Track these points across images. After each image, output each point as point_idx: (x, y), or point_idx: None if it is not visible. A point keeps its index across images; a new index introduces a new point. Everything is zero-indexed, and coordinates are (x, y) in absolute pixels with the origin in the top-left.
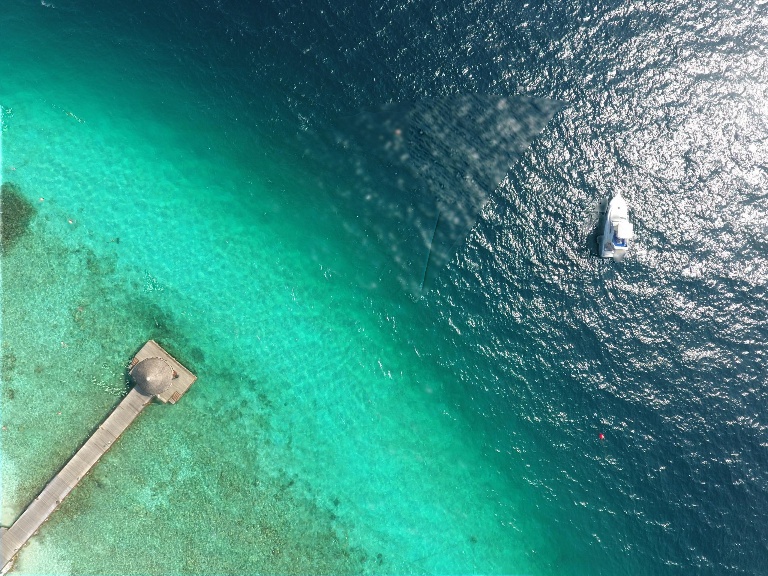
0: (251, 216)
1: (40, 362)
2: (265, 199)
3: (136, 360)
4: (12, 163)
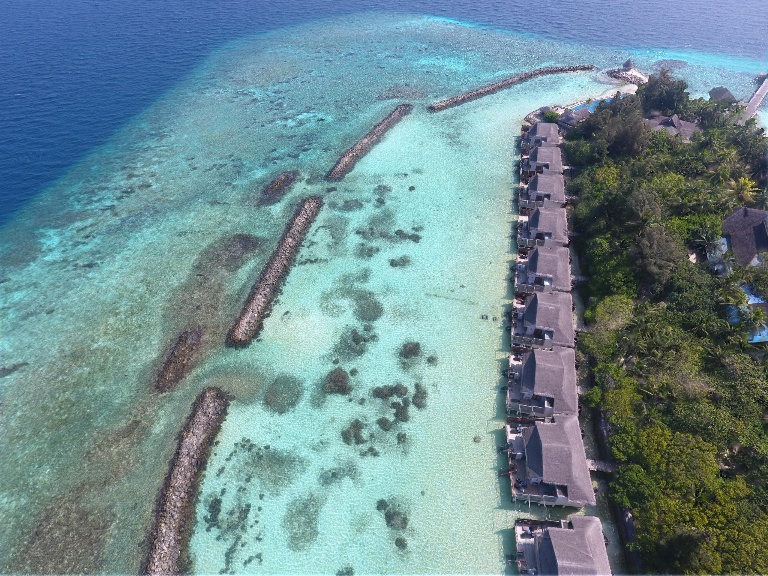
0: (762, 64)
1: (718, 82)
2: (765, 59)
3: (760, 75)
4: (673, 54)
